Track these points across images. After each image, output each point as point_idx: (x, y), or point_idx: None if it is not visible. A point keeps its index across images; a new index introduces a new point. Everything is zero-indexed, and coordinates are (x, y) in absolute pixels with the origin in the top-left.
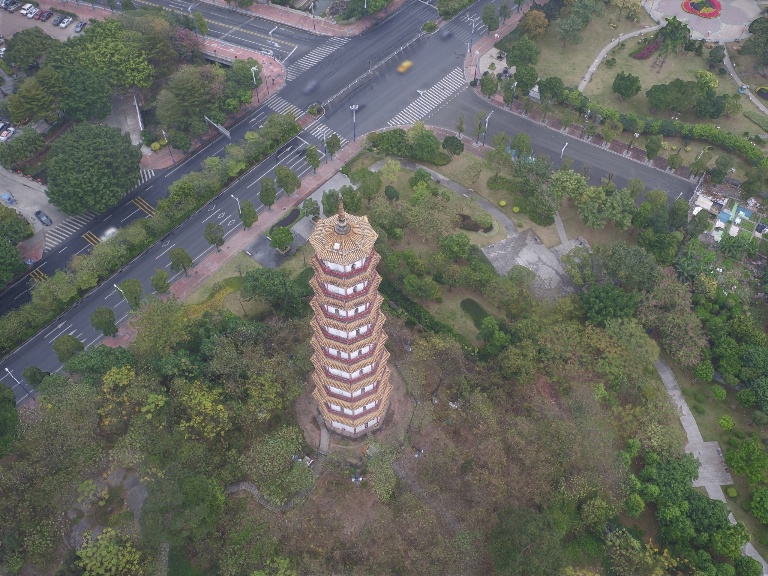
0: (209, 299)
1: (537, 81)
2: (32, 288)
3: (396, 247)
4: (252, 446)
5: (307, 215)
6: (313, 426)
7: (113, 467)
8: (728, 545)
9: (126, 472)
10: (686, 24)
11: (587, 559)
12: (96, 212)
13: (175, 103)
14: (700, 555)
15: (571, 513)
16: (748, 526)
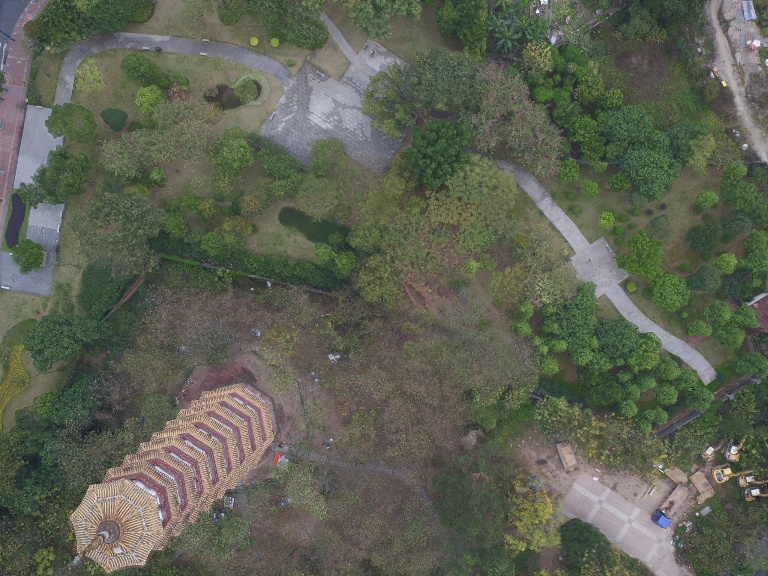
0: (6, 372)
1: None
2: None
3: (165, 185)
4: None
5: (34, 207)
6: None
7: None
8: (644, 366)
9: None
10: None
11: (523, 426)
12: None
13: None
14: (621, 379)
15: (494, 403)
16: (654, 312)
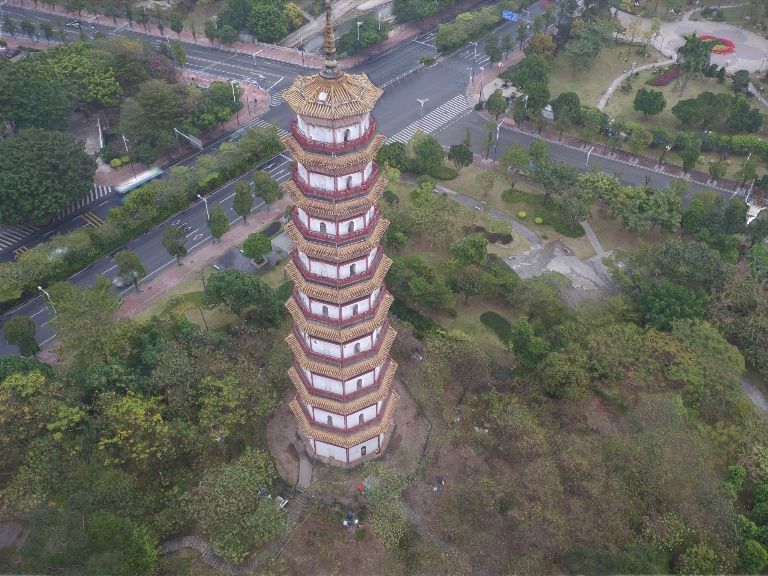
0: (162, 315)
1: (549, 102)
2: None
3: None
4: (202, 479)
5: None
6: (289, 456)
7: (1, 515)
8: None
9: (23, 528)
10: (706, 43)
11: None
12: (36, 227)
13: (141, 113)
14: None
15: None
16: None
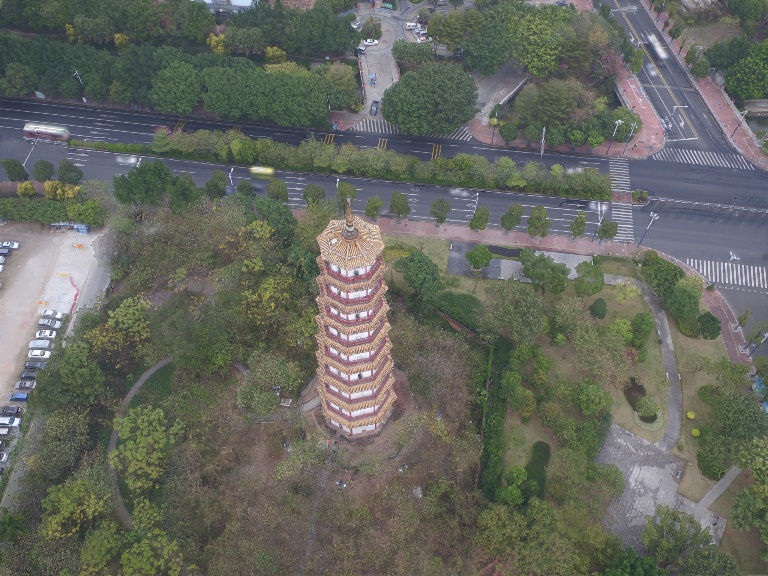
0: (388, 248)
1: None
2: (307, 140)
3: None
4: None
5: (517, 260)
6: None
7: (208, 279)
8: None
9: None
10: None
11: None
12: None
13: (533, 100)
14: None
15: None
16: None
